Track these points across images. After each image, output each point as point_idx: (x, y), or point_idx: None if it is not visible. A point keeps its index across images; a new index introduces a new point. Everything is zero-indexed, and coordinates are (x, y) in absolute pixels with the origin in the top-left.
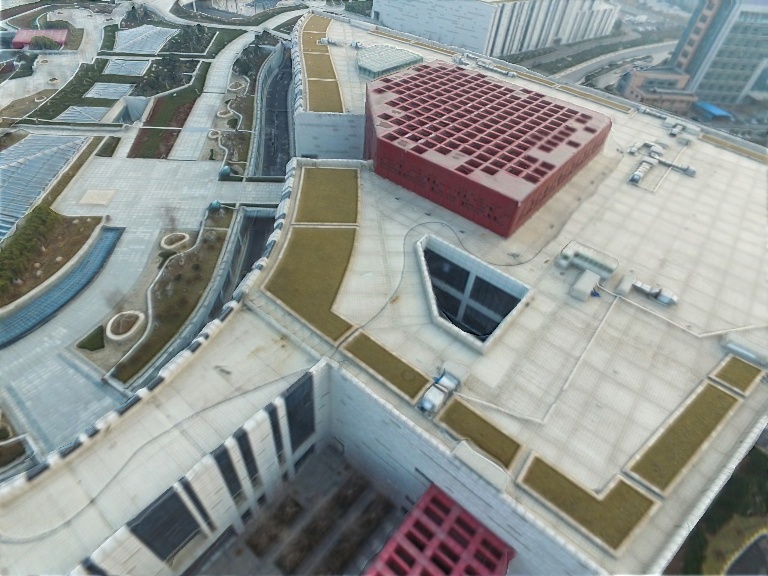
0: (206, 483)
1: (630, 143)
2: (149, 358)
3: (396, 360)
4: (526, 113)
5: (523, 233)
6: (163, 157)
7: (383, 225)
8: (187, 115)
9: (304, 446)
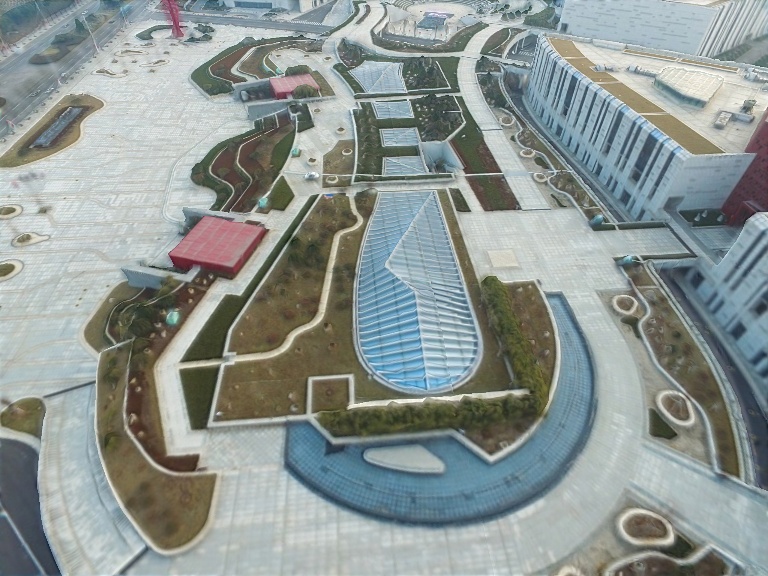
0: None
1: None
2: (733, 446)
3: None
4: None
5: None
6: (518, 208)
7: None
8: (492, 157)
9: None
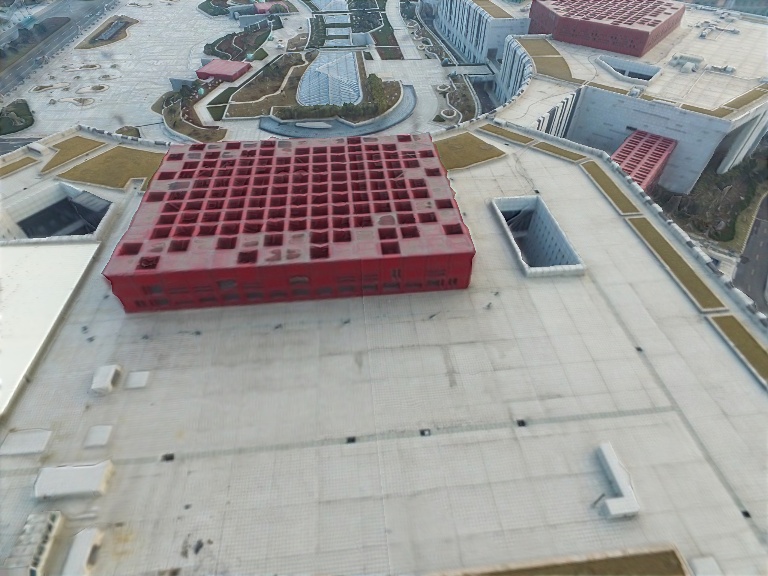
0: None
1: (696, 22)
2: None
3: (611, 87)
4: (634, 4)
5: (648, 56)
6: (402, 58)
7: (574, 56)
8: (396, 40)
9: None
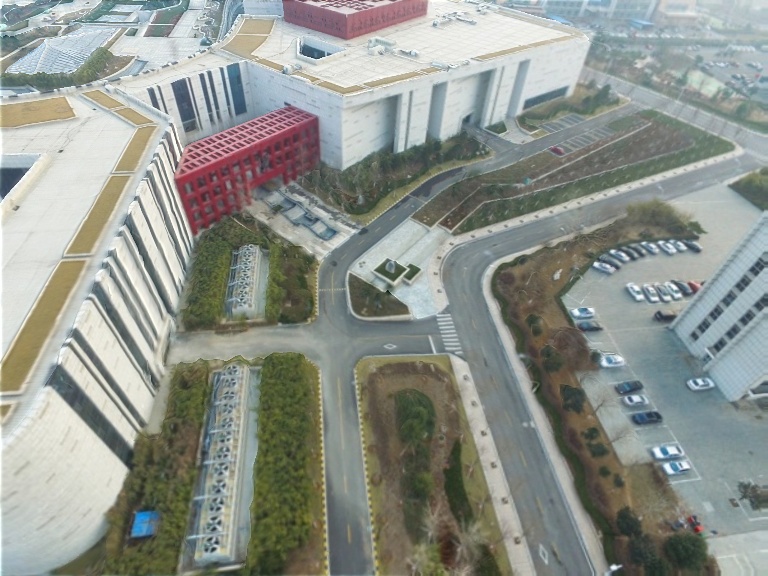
0: (196, 86)
1: None
2: None
3: (276, 64)
4: None
5: (357, 39)
6: (166, 36)
7: (283, 36)
8: (178, 19)
9: (242, 117)
